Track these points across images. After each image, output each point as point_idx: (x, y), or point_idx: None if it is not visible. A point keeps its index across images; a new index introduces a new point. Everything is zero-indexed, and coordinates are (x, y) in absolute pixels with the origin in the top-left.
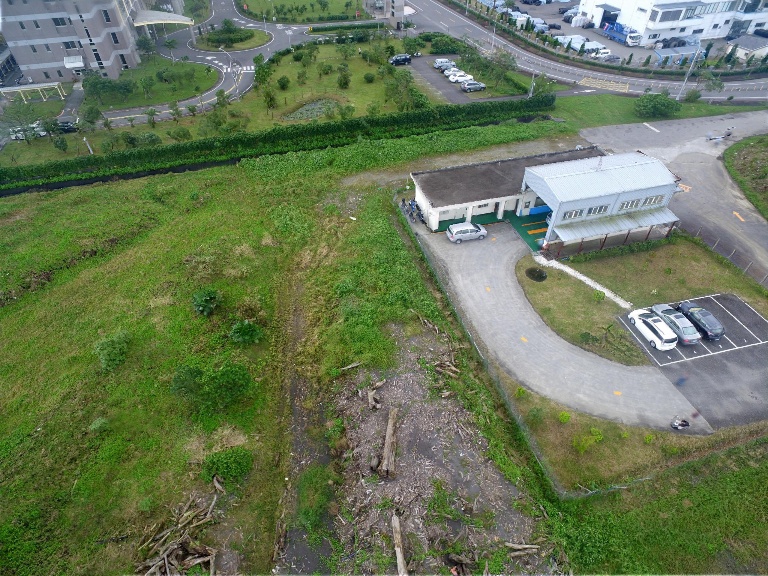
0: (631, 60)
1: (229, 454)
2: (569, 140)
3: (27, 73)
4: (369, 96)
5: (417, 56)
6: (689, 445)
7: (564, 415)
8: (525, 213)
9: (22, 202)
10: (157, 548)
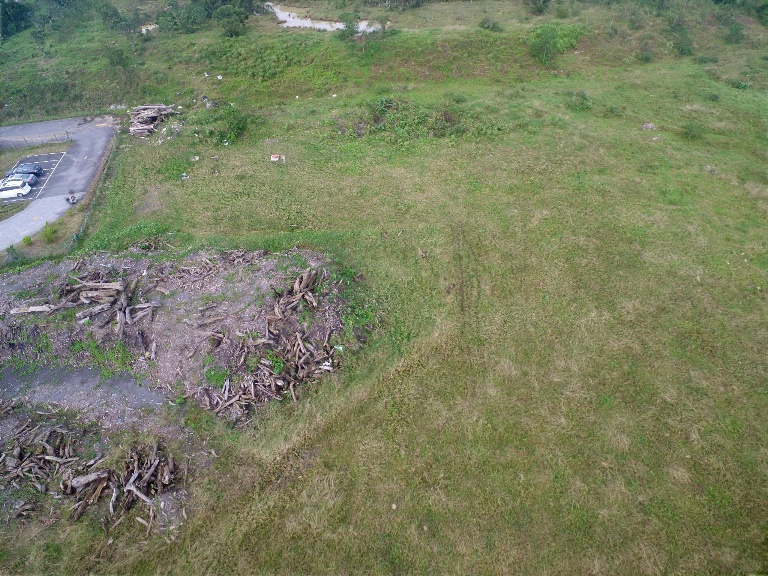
0: None
1: None
2: None
3: None
4: None
5: None
6: (86, 202)
7: (25, 238)
8: None
9: None
10: None
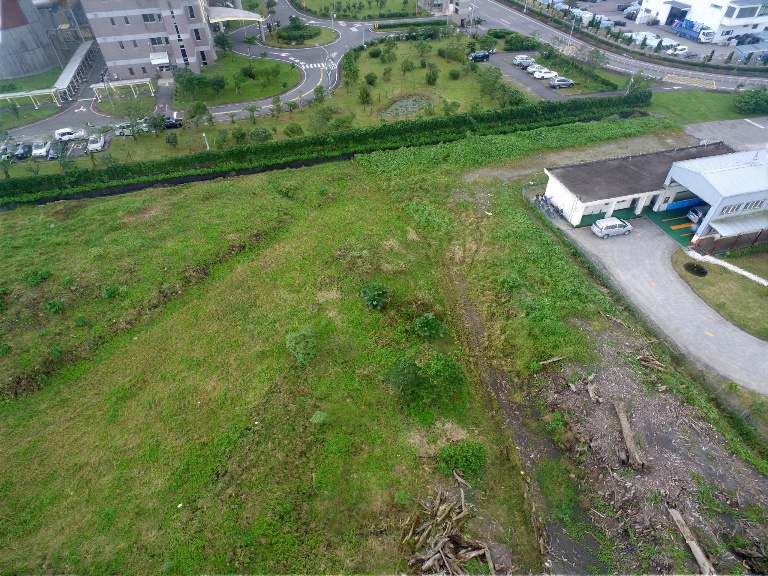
0: (712, 57)
1: (465, 447)
2: (676, 136)
3: (113, 69)
4: (459, 92)
5: (492, 53)
6: None
7: None
8: (662, 208)
9: (151, 197)
10: (423, 541)
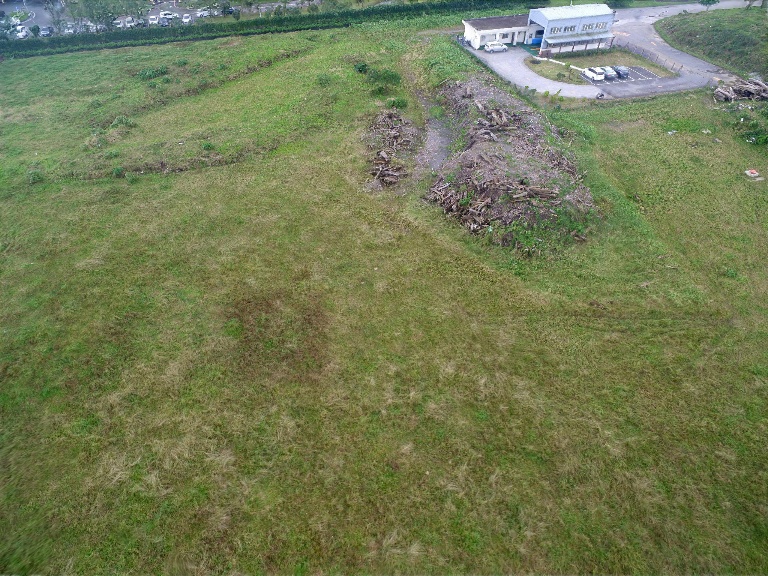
0: None
1: (398, 98)
2: None
3: None
4: None
5: None
6: (603, 102)
7: None
8: (529, 42)
9: (231, 39)
10: None
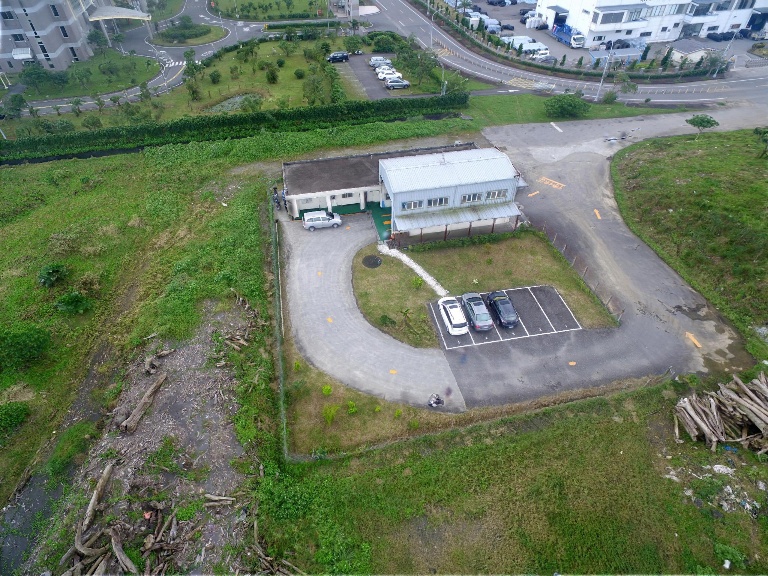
0: (565, 61)
1: (3, 407)
2: (468, 137)
3: None
4: (293, 91)
5: (358, 54)
6: (437, 421)
7: (325, 388)
8: (388, 204)
9: None
10: None
